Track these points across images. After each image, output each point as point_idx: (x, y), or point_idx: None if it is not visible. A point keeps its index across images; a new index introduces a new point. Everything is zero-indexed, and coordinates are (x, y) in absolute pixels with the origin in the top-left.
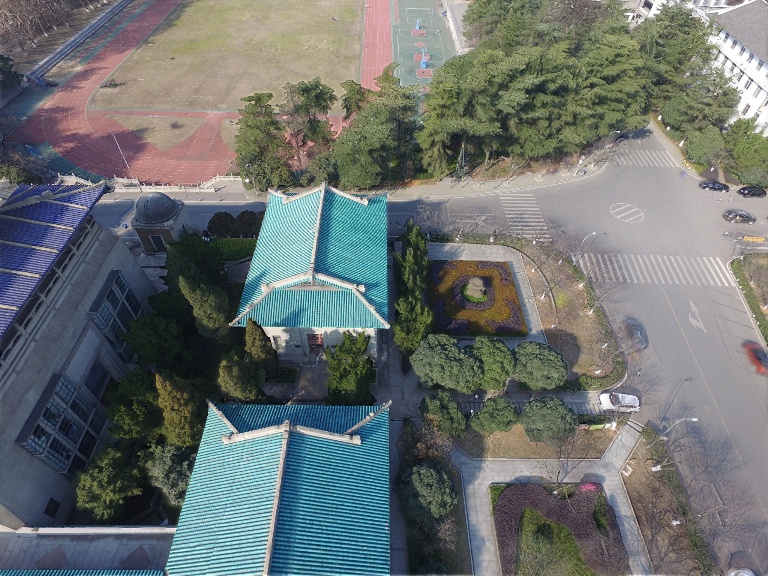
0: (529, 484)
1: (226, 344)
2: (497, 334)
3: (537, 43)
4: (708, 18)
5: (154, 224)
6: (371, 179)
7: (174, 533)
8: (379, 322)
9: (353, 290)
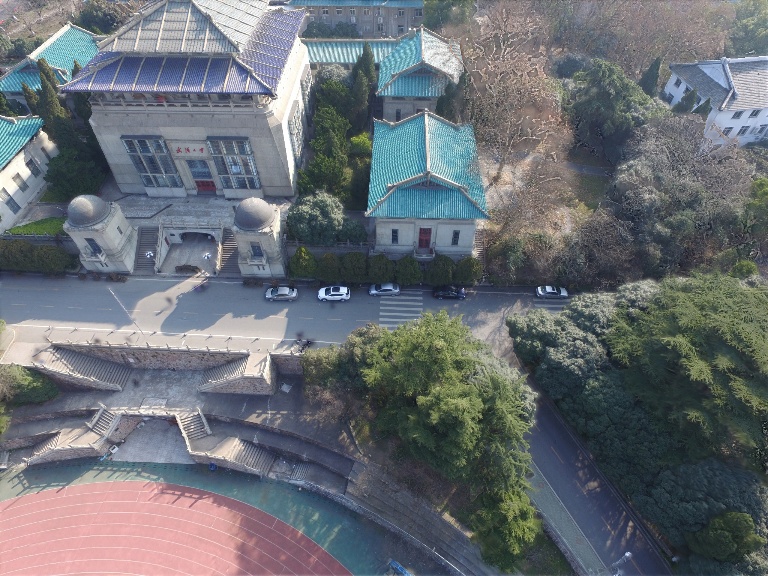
0: None
1: None
2: None
3: None
4: None
5: None
6: None
7: None
8: None
9: None
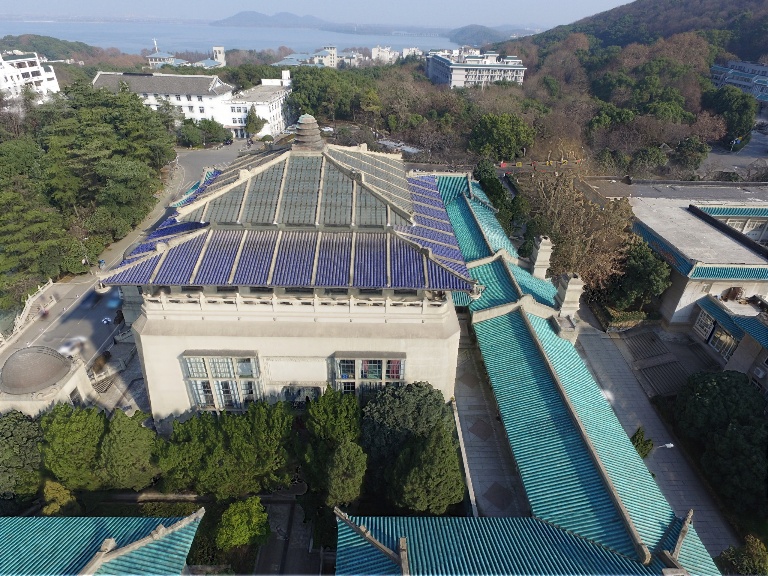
0: None
1: None
2: None
3: (12, 137)
4: None
5: None
6: None
7: None
8: None
9: None
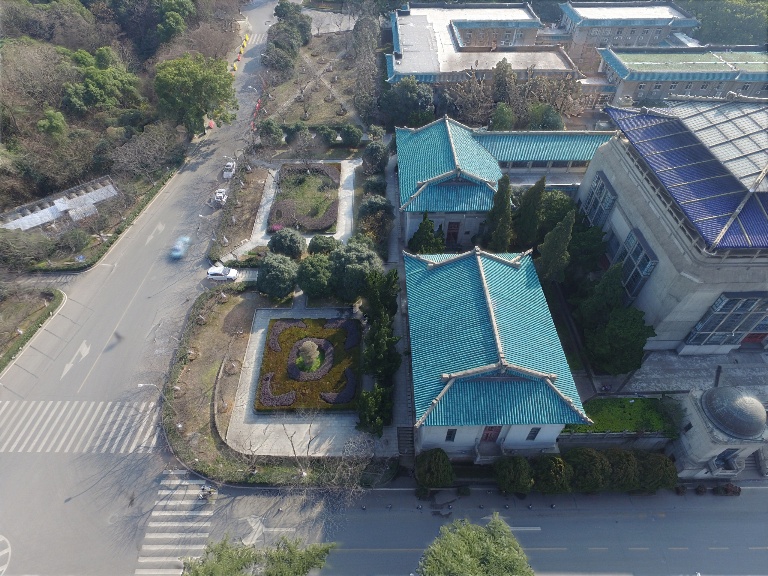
0: (312, 228)
1: None
2: (299, 319)
3: None
4: None
5: None
6: None
7: None
8: None
9: None
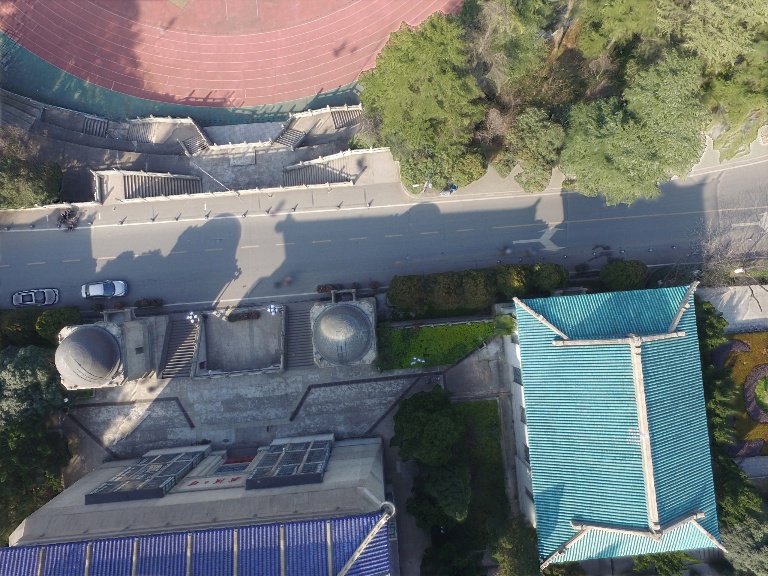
0: None
1: (485, 503)
2: None
3: None
4: None
5: (351, 363)
6: (634, 197)
7: None
8: (712, 543)
9: None
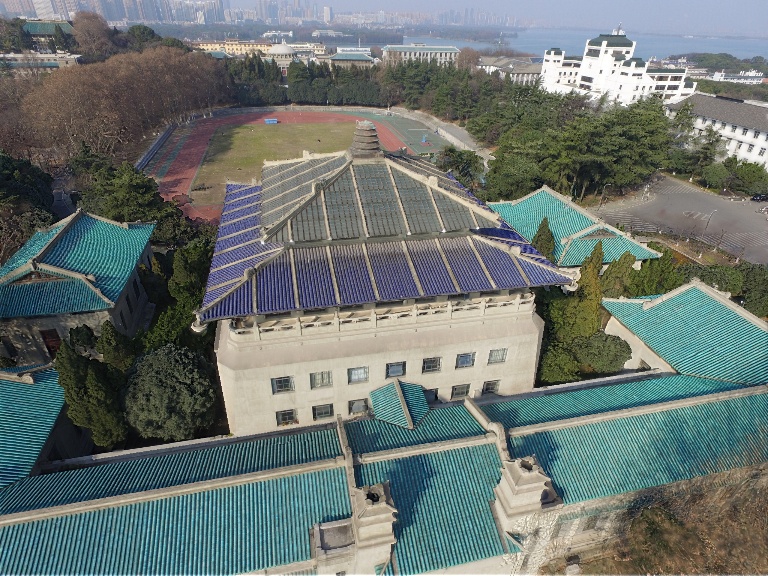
0: None
1: None
2: None
3: None
4: (667, 107)
5: None
6: None
7: (641, 376)
8: (652, 253)
9: (624, 236)
